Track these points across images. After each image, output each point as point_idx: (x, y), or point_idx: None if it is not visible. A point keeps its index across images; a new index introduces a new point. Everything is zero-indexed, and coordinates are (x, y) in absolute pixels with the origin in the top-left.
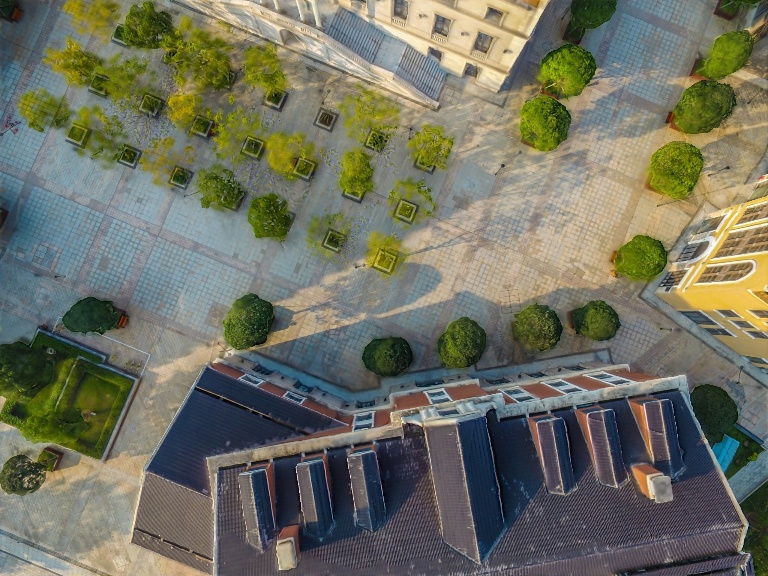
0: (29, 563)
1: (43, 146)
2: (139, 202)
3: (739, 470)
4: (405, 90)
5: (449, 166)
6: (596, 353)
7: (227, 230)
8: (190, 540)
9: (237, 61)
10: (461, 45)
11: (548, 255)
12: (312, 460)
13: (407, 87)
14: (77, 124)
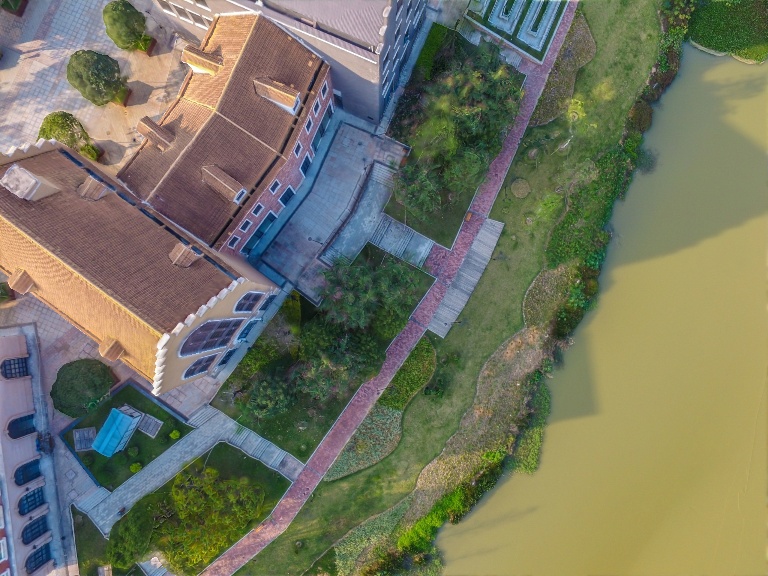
0: None
1: None
2: None
3: (168, 448)
4: None
5: None
6: (22, 327)
7: None
8: None
9: None
10: None
11: None
12: None
13: None
14: None
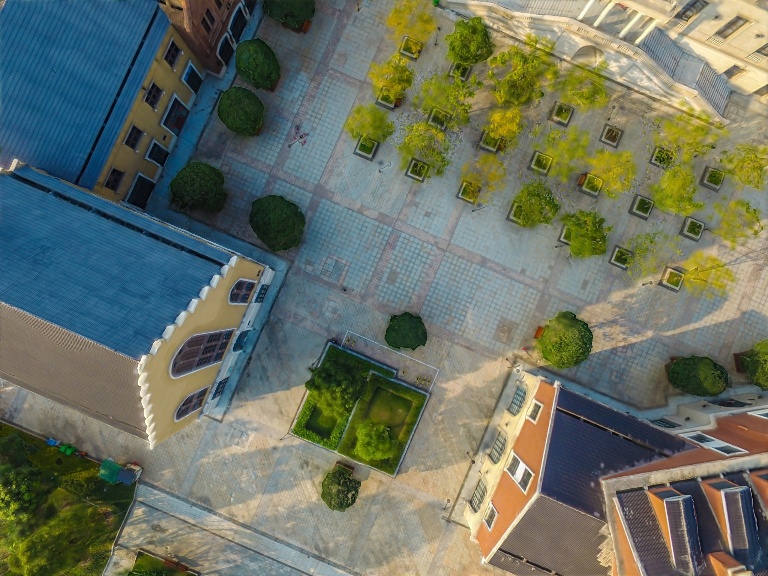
0: None
1: (331, 158)
2: (427, 216)
3: None
4: (698, 108)
5: (734, 184)
6: None
7: (515, 245)
8: (557, 562)
9: None
10: None
11: None
12: (735, 486)
13: (704, 105)
14: None
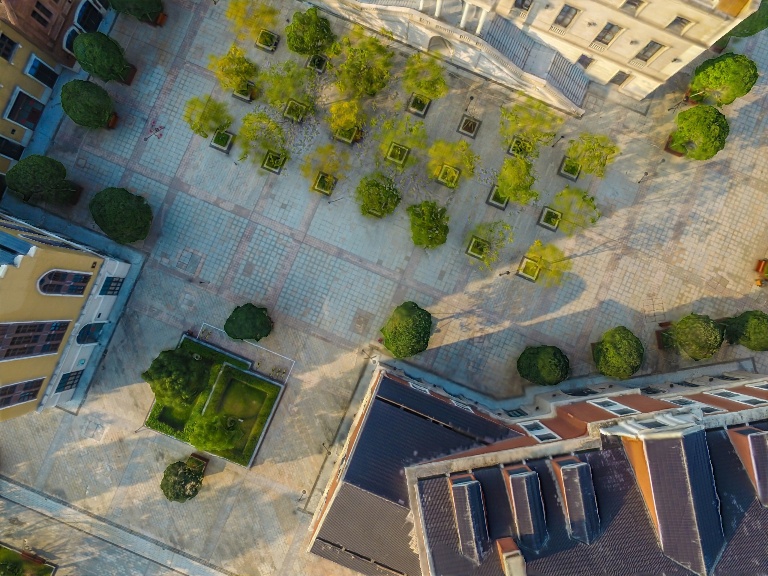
0: (171, 570)
1: (187, 151)
2: (283, 208)
3: None
4: (552, 97)
5: (592, 174)
6: (740, 362)
7: (371, 237)
8: (374, 550)
9: None
10: (622, 53)
11: (692, 264)
12: (524, 472)
13: (556, 95)
14: None
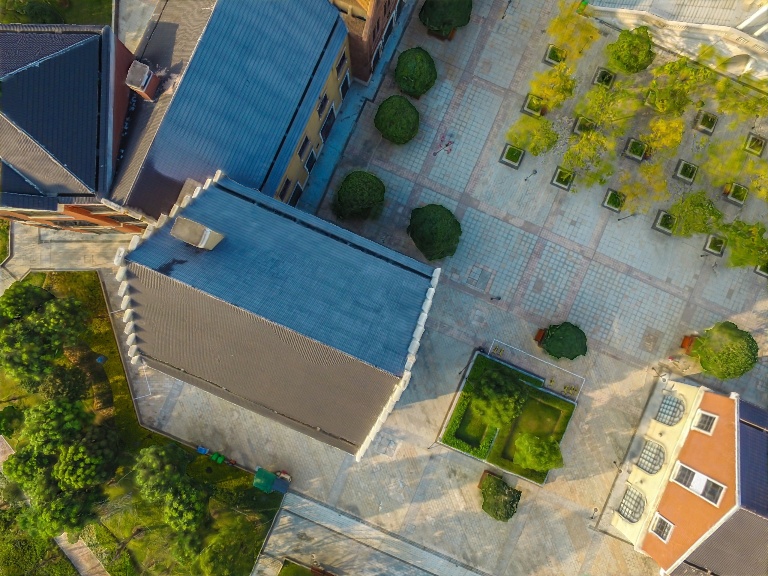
0: None
1: (476, 166)
2: (573, 225)
3: None
4: None
5: None
6: None
7: (660, 254)
8: (744, 574)
9: (667, 84)
10: None
11: None
12: None
13: None
14: (511, 145)
